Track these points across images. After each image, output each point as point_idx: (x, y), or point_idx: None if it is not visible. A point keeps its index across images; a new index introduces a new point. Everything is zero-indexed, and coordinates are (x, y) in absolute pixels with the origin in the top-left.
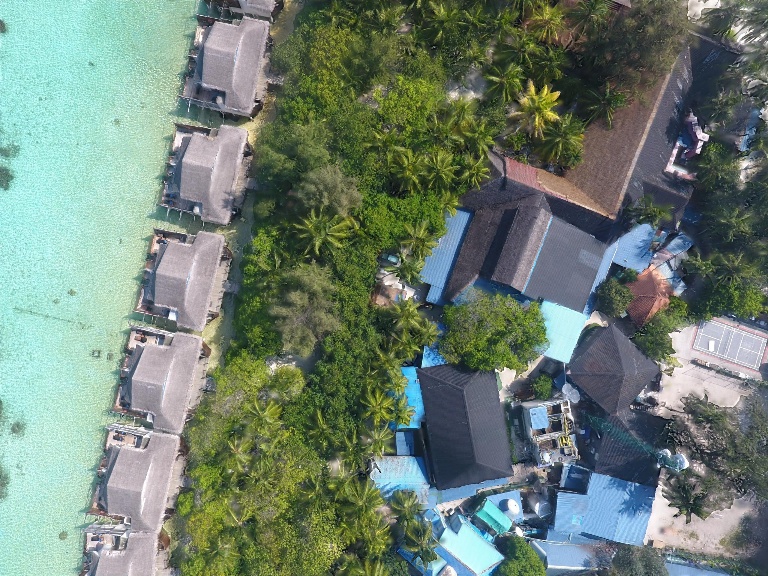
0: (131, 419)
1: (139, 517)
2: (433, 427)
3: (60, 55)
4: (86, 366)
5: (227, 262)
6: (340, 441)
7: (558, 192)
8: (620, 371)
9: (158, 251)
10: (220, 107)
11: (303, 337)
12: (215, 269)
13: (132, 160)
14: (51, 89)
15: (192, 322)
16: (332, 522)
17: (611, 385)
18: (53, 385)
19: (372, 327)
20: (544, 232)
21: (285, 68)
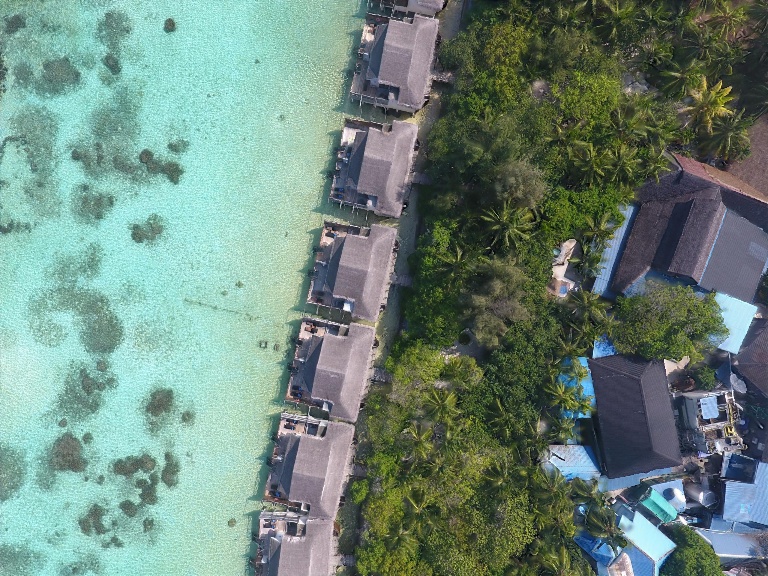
0: (297, 409)
1: (319, 504)
2: (605, 416)
3: (227, 53)
4: (254, 356)
5: (394, 255)
6: (524, 429)
7: (731, 185)
8: None
9: (333, 243)
10: (388, 103)
11: (494, 327)
12: (388, 261)
13: (297, 155)
14: (219, 86)
15: (367, 313)
16: (526, 508)
17: None
18: (222, 375)
19: (551, 317)
20: (720, 224)
21: (452, 65)
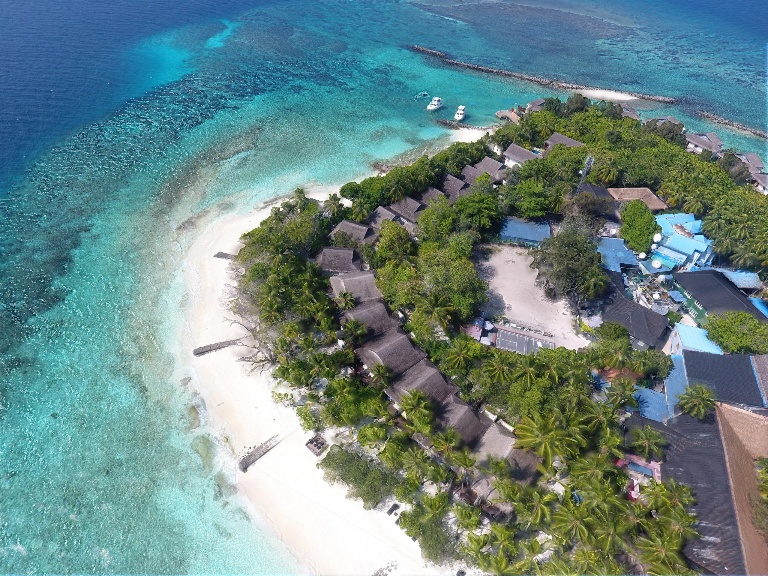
0: None
1: None
2: None
3: None
4: None
5: None
6: None
7: None
8: (646, 312)
9: None
10: None
11: None
12: None
13: None
14: None
15: None
16: None
17: None
18: None
19: None
20: (766, 394)
21: None
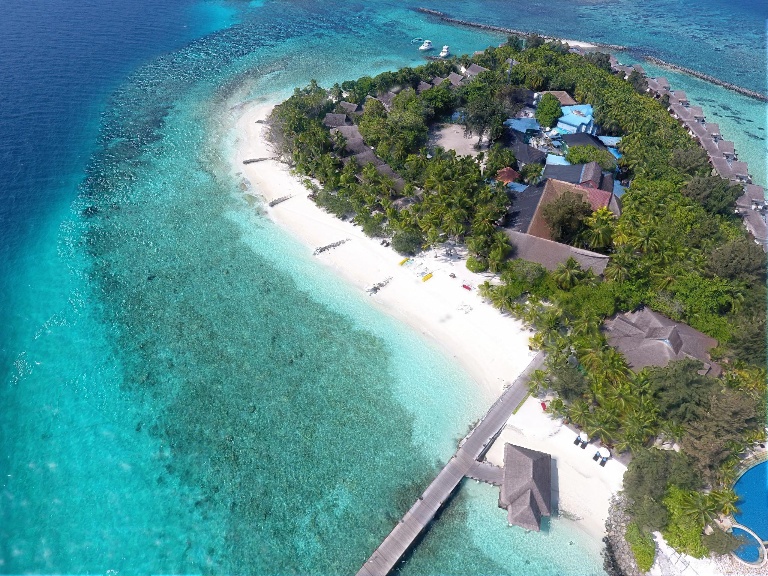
0: None
1: None
2: None
3: None
4: None
5: None
6: None
7: (579, 190)
8: (528, 146)
9: None
10: None
11: None
12: None
13: None
14: None
15: None
16: None
17: None
18: None
19: None
20: None
21: None
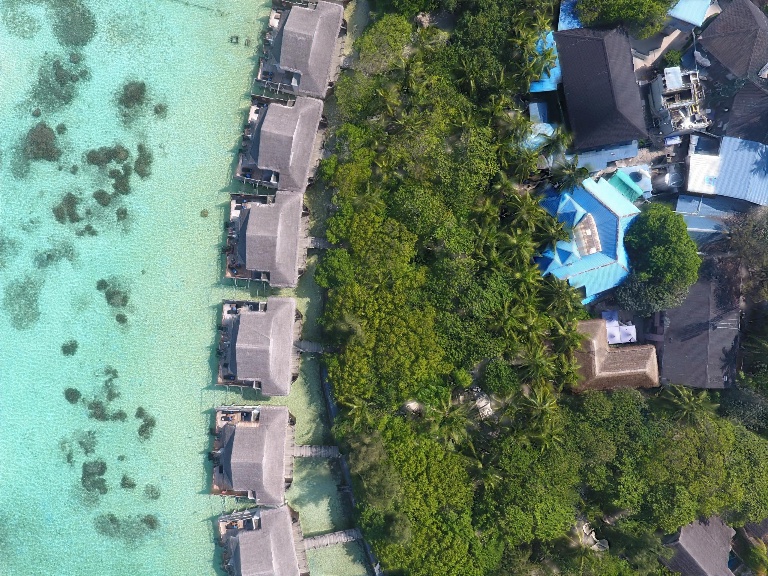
0: None
1: (288, 170)
2: (570, 86)
3: None
4: (225, 51)
5: None
6: (488, 80)
7: None
8: (754, 25)
9: None
10: None
11: None
12: None
13: None
14: None
15: None
16: (488, 139)
17: (744, 43)
18: (193, 69)
19: None
20: None
21: None
